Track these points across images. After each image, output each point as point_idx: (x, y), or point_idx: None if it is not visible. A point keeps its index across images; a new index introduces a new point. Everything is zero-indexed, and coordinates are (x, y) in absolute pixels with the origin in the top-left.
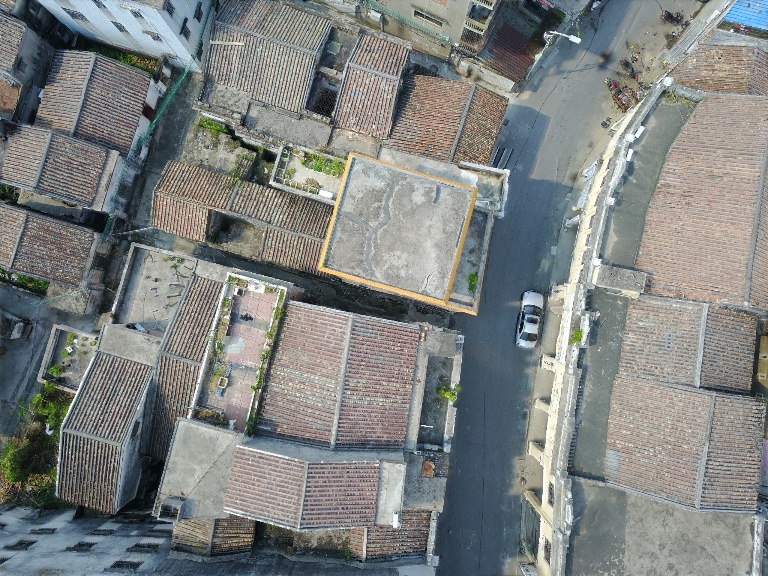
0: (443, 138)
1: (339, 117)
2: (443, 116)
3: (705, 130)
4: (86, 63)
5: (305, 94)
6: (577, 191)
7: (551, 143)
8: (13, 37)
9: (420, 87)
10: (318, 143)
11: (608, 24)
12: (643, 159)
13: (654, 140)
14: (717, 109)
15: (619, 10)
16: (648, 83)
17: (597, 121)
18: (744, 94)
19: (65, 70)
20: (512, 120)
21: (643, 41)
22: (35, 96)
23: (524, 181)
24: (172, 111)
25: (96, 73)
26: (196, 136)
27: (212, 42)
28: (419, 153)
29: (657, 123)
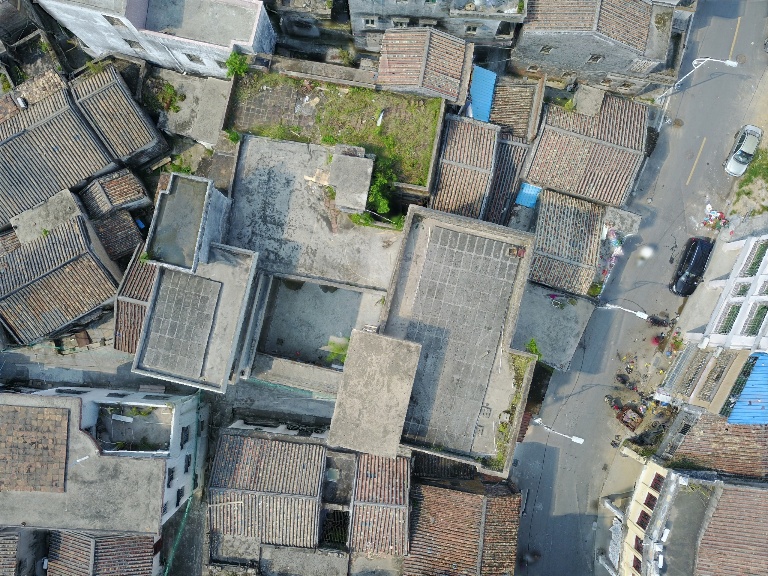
0: (465, 555)
1: (354, 545)
2: (460, 531)
3: (731, 524)
4: (86, 546)
5: (315, 532)
6: (602, 519)
7: (565, 475)
8: (8, 551)
9: (429, 499)
10: (338, 572)
11: (595, 340)
12: (674, 553)
13: (680, 531)
14: (739, 502)
15: (603, 323)
16: (649, 393)
17: (606, 442)
18: (764, 489)
19: (65, 549)
20: (521, 459)
21: (634, 349)
22: (40, 569)
23: (547, 520)
24: (178, 530)
25: (99, 554)
26: (211, 573)
27: (210, 506)
28: (444, 571)
29: (679, 513)
